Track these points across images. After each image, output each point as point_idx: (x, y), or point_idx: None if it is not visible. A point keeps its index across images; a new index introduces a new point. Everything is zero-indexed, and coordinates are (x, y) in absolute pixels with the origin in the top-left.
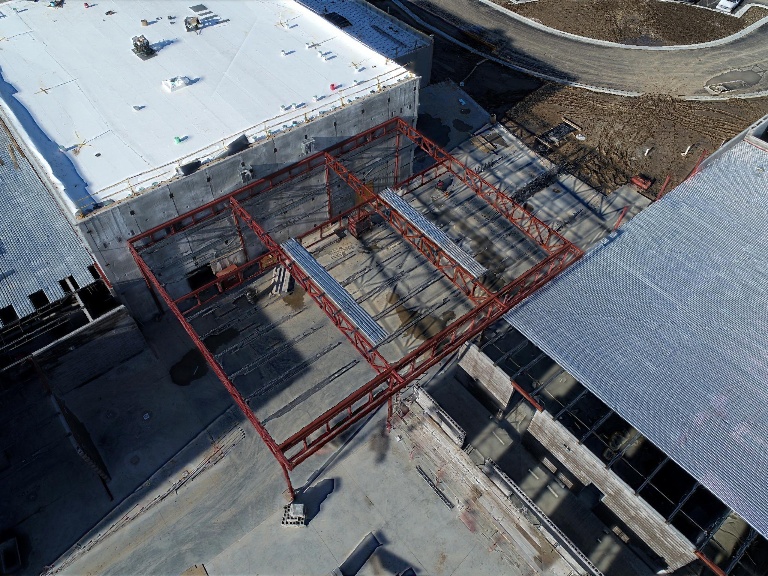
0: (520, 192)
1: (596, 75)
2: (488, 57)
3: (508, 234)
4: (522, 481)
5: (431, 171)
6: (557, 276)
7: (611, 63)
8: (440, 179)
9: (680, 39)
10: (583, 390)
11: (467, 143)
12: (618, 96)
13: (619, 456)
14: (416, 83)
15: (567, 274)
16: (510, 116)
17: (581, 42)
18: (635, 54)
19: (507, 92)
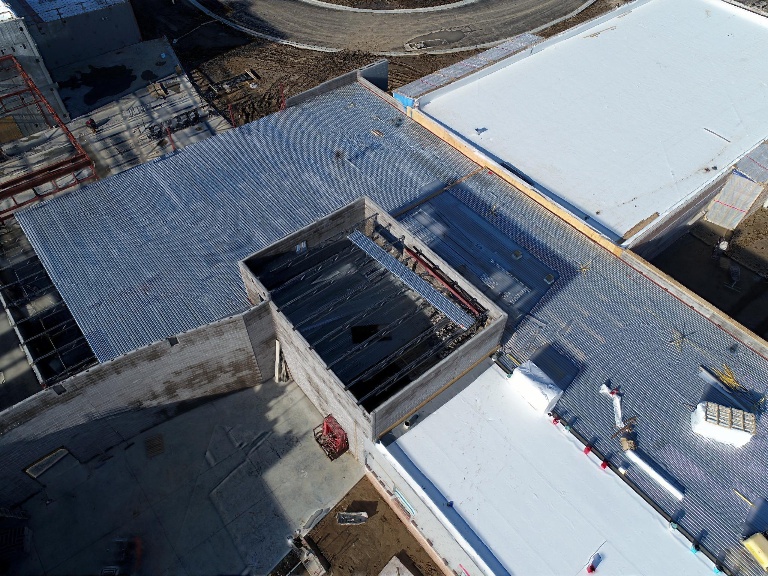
0: (152, 128)
1: (310, 34)
2: (219, 19)
3: (129, 164)
4: (7, 352)
5: (94, 112)
6: (90, 186)
7: (332, 24)
8: (98, 119)
9: (412, 4)
10: (40, 270)
11: (144, 90)
12: (316, 51)
13: (31, 317)
14: (20, 24)
15: (100, 184)
16: (201, 68)
17: (316, 6)
18: (360, 16)
19: (212, 48)
